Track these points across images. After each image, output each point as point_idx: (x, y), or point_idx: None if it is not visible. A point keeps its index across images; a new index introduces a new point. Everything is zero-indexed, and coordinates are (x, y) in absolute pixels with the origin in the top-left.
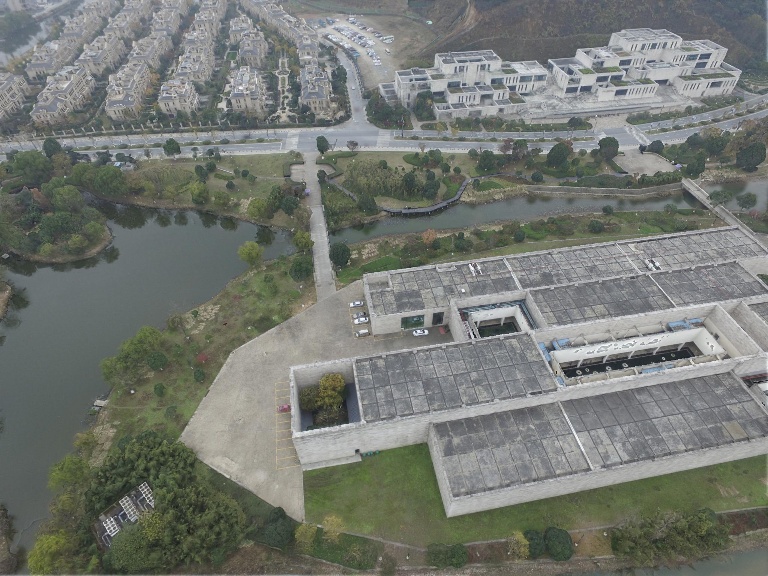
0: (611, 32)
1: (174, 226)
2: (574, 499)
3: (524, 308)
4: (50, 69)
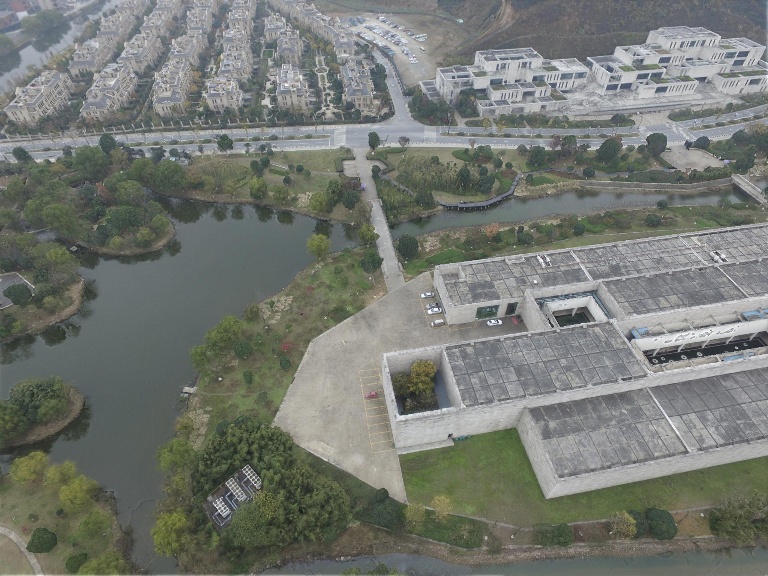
0: (647, 30)
1: (230, 220)
2: (667, 482)
3: (596, 299)
4: (92, 67)
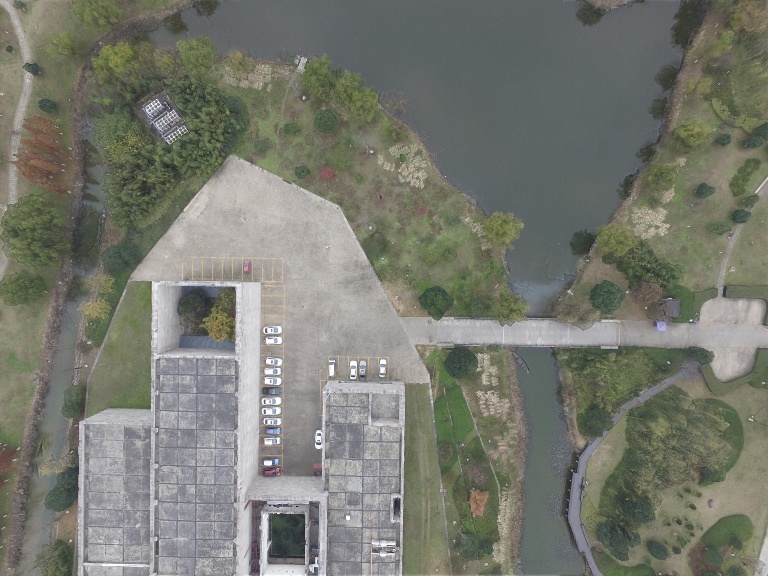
0: None
1: None
2: None
3: None
4: None
